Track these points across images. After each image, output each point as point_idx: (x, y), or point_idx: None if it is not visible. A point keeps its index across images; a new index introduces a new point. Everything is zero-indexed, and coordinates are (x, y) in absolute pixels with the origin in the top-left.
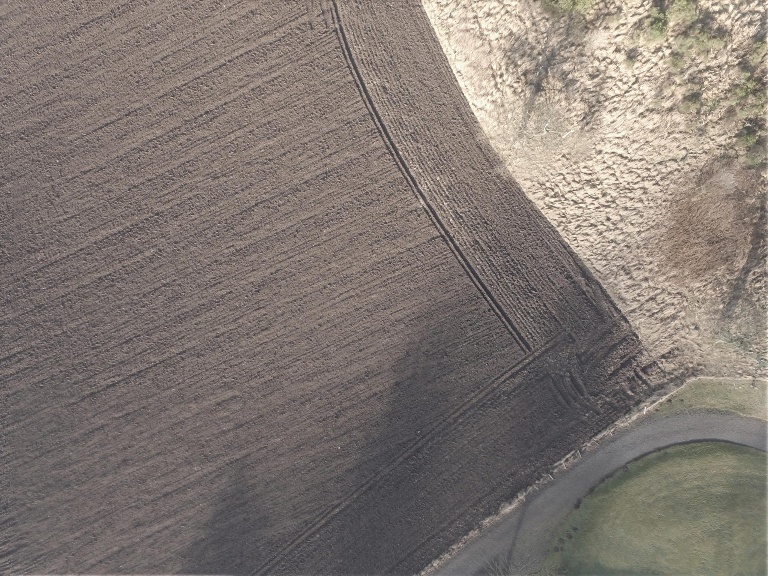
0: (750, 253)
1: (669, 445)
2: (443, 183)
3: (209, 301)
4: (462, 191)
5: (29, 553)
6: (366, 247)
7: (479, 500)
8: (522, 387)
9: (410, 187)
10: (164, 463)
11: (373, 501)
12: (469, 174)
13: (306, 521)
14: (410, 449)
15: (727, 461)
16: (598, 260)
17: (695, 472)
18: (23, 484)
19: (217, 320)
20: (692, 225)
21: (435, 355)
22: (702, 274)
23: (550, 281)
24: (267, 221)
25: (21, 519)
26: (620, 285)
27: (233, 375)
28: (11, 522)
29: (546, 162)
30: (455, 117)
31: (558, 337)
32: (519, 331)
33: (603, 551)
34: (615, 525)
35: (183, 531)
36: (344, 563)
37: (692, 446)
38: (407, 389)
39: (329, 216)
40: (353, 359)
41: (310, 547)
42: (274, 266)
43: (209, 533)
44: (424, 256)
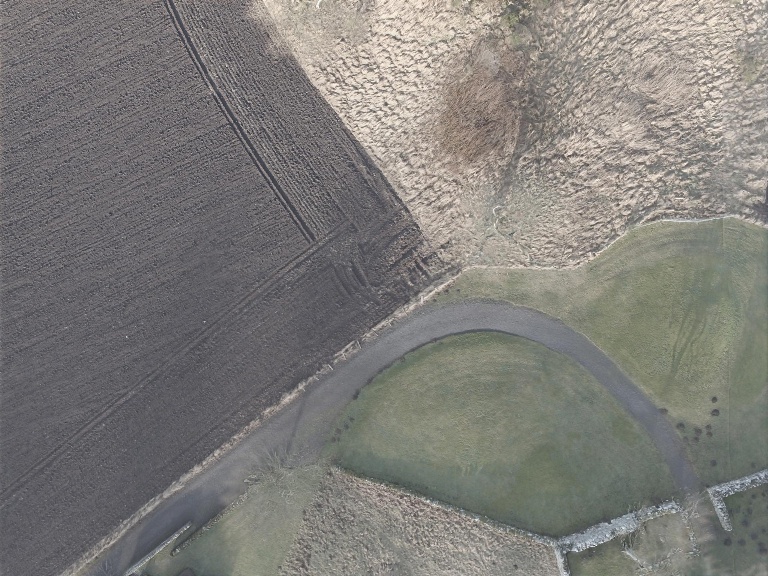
0: (519, 138)
1: (445, 335)
2: (231, 70)
3: (4, 188)
4: (250, 78)
5: None
6: (157, 135)
7: (262, 391)
8: (306, 277)
9: (200, 74)
10: None
11: (158, 391)
12: (256, 60)
13: (93, 410)
14: (196, 339)
15: (497, 350)
16: (377, 147)
17: (467, 361)
18: None
19: (11, 208)
20: (462, 108)
21: (222, 244)
22: (474, 159)
23: (333, 169)
24: (62, 108)
25: None
26: (399, 173)
27: (25, 263)
28: None
29: (327, 46)
30: (244, 3)
31: (341, 227)
32: (304, 221)
33: (375, 440)
34: (388, 414)
35: None
36: (128, 453)
37: (466, 336)
38: (194, 278)
39: (122, 103)
40: (142, 248)
41: (96, 436)
42: (68, 154)
43: None
44: (213, 144)
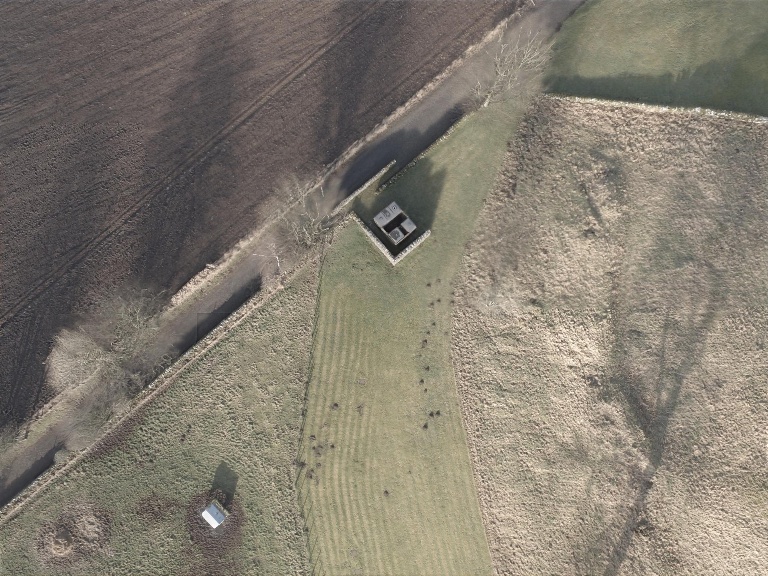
0: None
1: None
2: None
3: None
4: None
5: (19, 92)
6: None
7: (463, 32)
8: None
9: None
10: (154, 9)
11: (359, 38)
12: None
13: (293, 61)
14: None
15: None
16: None
17: None
18: (14, 27)
19: None
20: None
21: None
22: None
23: None
24: None
25: (11, 60)
26: None
27: None
28: (1, 62)
29: None
30: None
31: None
32: None
33: (582, 63)
34: (594, 38)
35: (172, 74)
36: (330, 100)
37: None
38: None
39: None
40: None
41: (297, 87)
42: None
43: (197, 76)
44: None
